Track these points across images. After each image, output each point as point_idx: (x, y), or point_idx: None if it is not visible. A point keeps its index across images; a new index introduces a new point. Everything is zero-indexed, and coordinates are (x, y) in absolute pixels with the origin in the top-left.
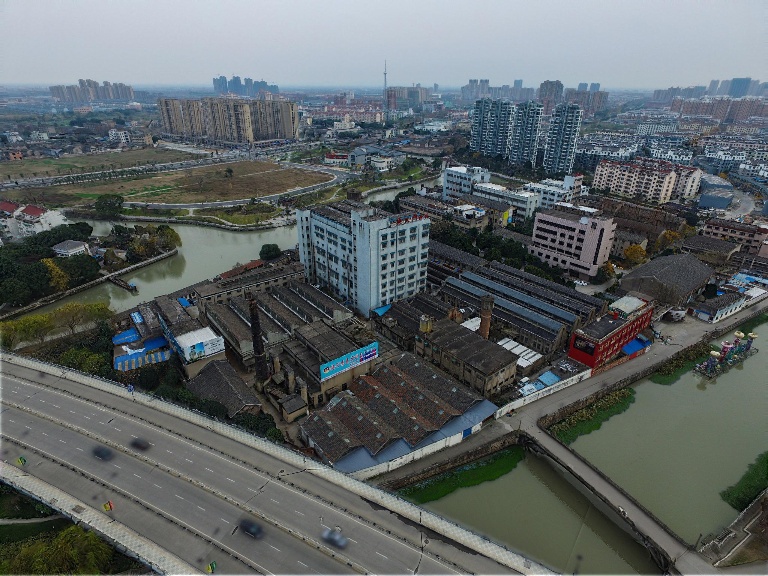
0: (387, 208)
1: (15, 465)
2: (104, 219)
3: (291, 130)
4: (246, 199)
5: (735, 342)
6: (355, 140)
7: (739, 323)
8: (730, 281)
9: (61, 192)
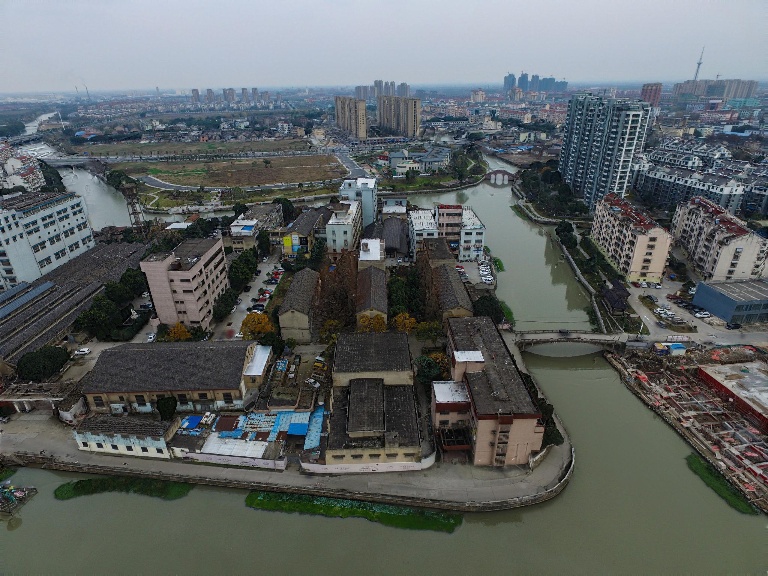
0: (237, 212)
1: None
2: (118, 188)
3: (412, 128)
4: (217, 187)
5: None
6: (475, 142)
7: (109, 470)
8: (254, 414)
9: (150, 166)
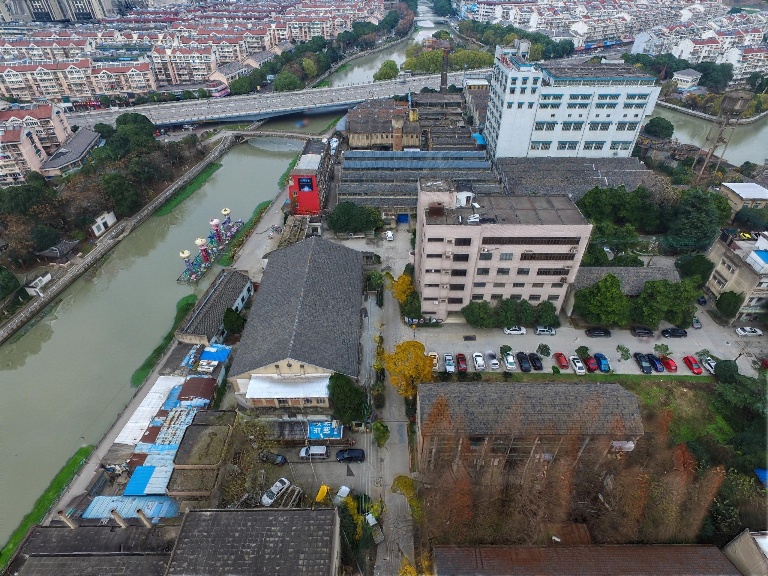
0: None
1: (439, 76)
2: None
3: None
4: None
5: (205, 248)
6: None
7: None
8: None
9: None
